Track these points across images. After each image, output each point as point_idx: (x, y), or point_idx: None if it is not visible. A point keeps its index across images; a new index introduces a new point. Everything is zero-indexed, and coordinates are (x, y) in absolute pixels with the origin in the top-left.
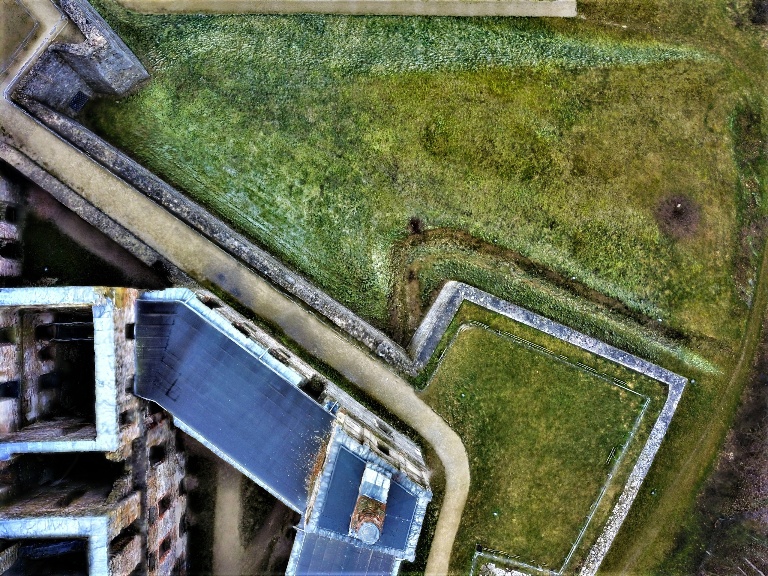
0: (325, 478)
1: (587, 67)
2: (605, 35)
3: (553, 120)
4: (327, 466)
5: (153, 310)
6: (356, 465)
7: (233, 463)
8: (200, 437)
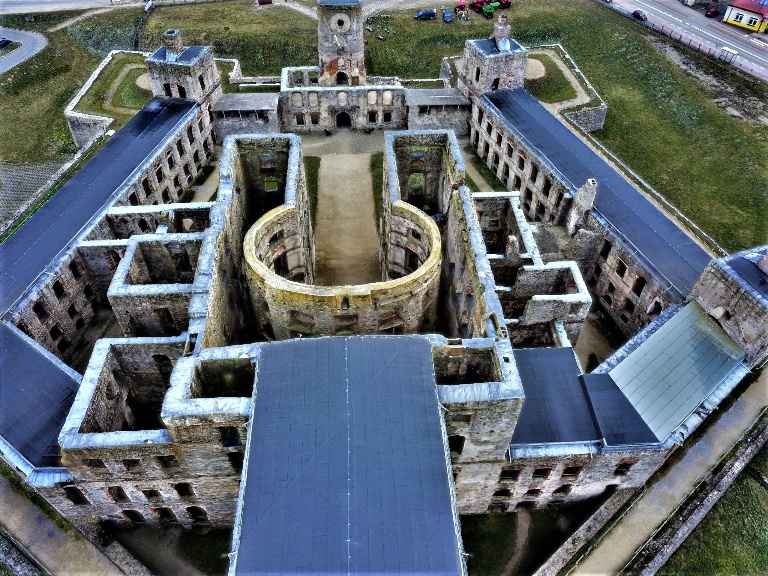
0: None
1: None
2: None
3: None
4: None
5: None
6: None
7: (44, 351)
8: (64, 368)
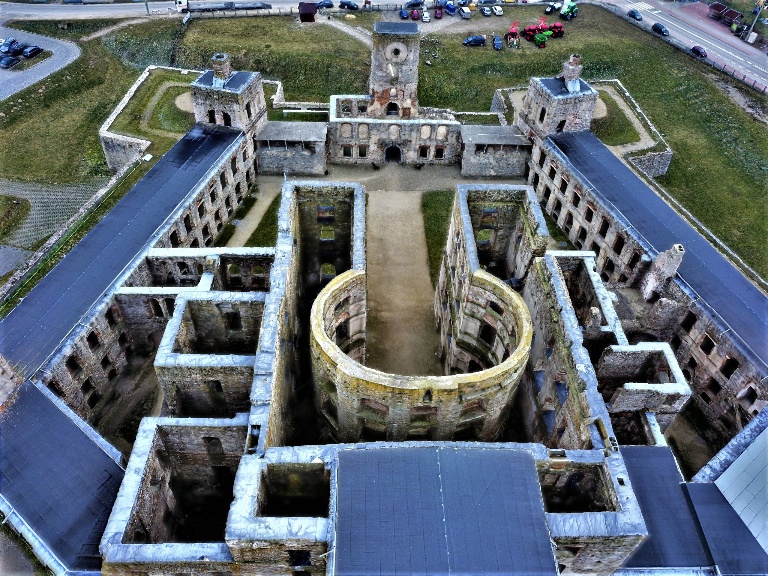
0: None
1: None
2: None
3: None
4: None
5: (100, 561)
6: None
7: (79, 421)
8: (101, 442)
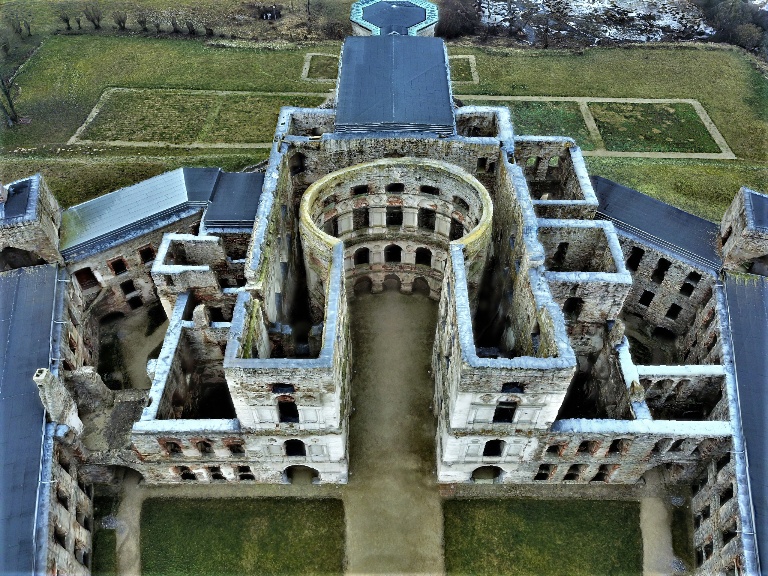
0: (747, 206)
1: (760, 169)
2: (760, 165)
3: (753, 185)
4: (746, 201)
5: None
6: (765, 198)
7: (657, 248)
8: (629, 236)
